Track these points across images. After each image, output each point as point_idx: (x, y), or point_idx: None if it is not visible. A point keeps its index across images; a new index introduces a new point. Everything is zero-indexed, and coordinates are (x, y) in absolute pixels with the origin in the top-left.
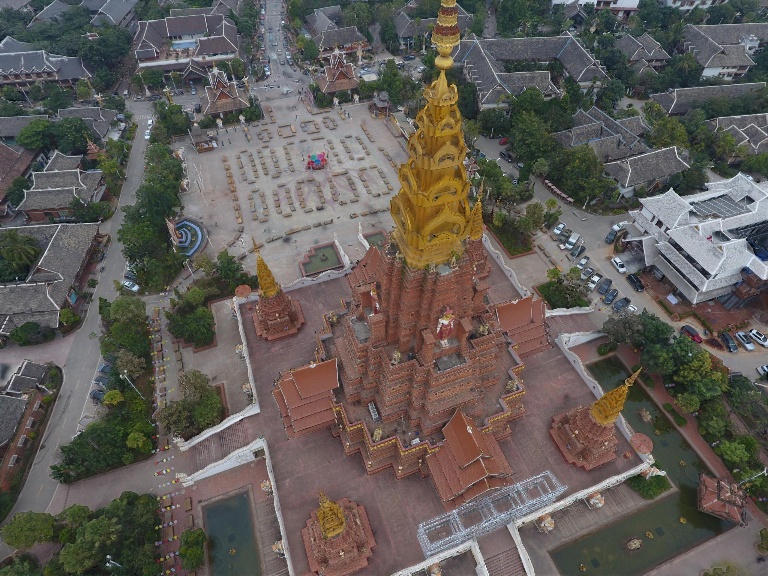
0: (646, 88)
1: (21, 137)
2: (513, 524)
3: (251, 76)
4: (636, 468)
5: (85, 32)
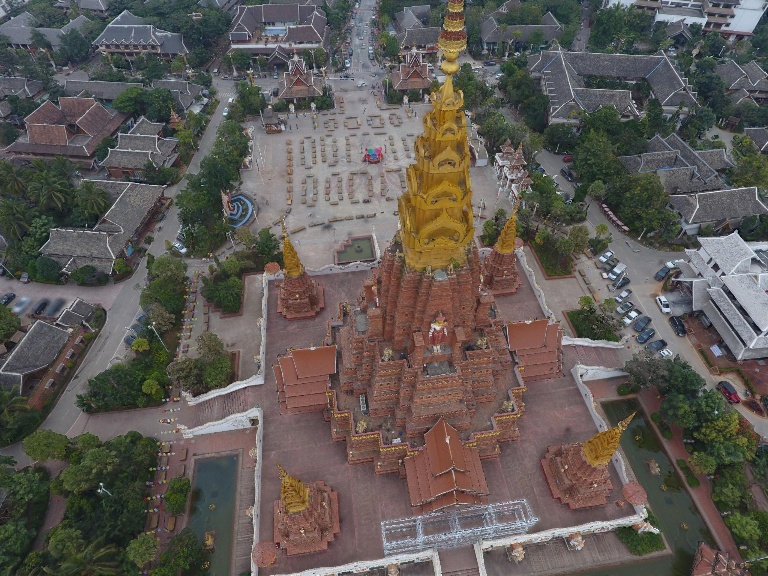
0: (742, 120)
1: (117, 101)
2: (478, 544)
3: (331, 66)
4: (625, 518)
5: (191, 12)
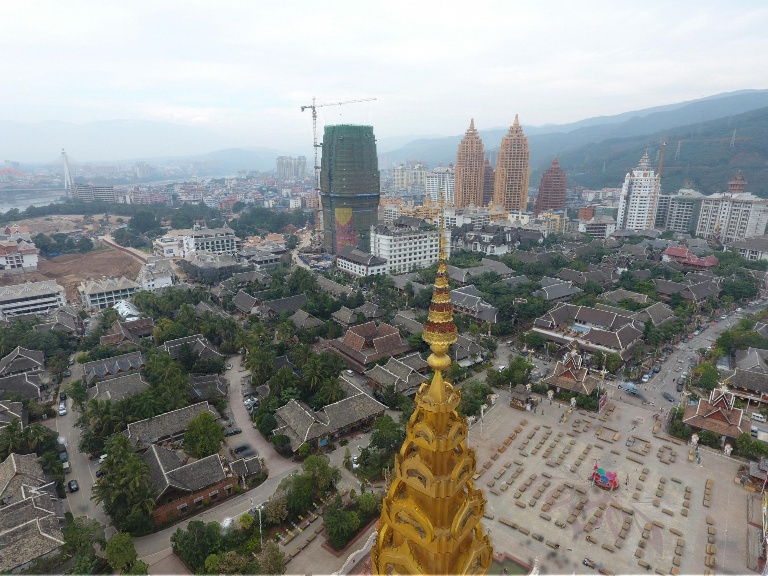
0: None
1: (412, 336)
2: None
3: (622, 374)
4: None
5: (520, 297)
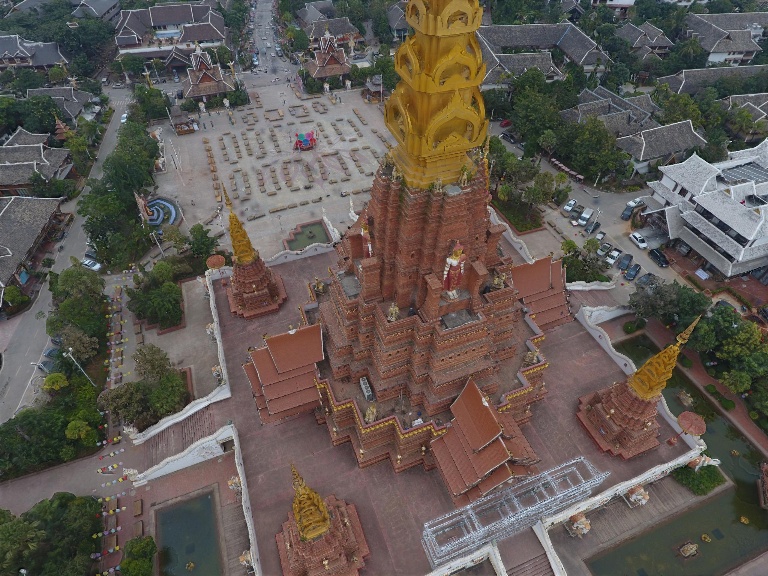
0: (651, 74)
1: None
2: (541, 524)
3: (238, 65)
4: (686, 455)
5: (65, 21)
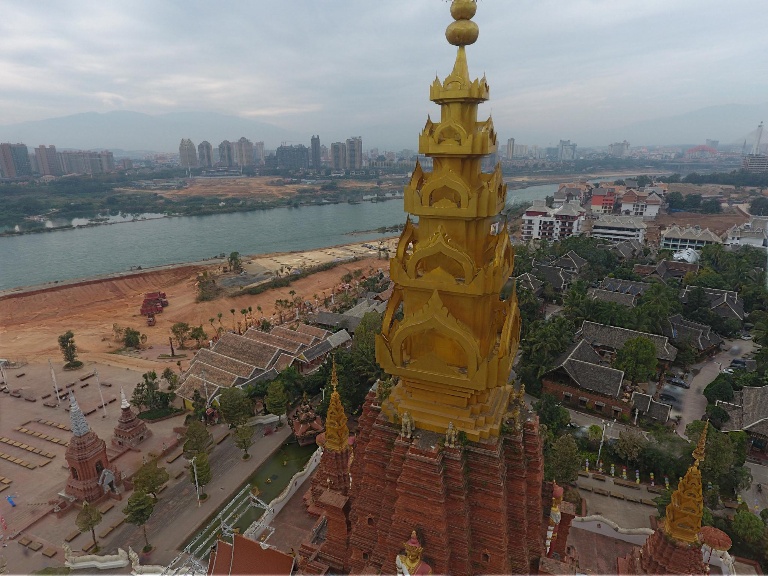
0: None
1: None
2: None
3: None
4: None
5: None
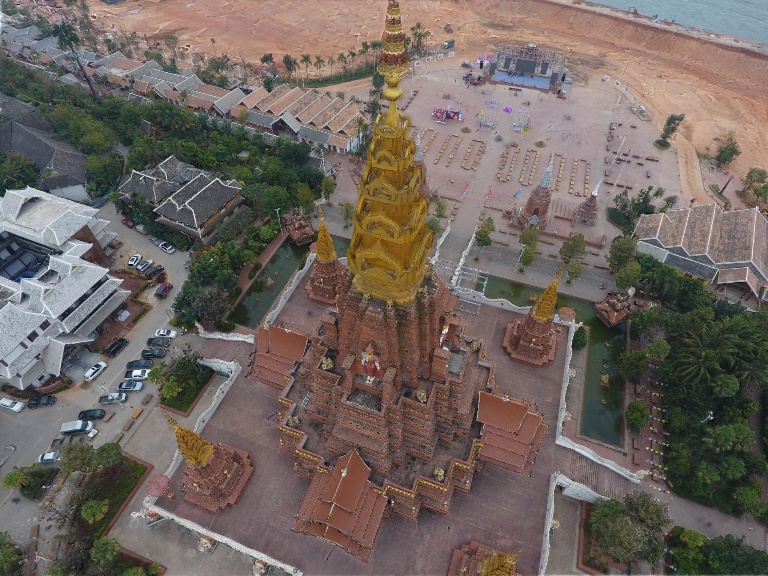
0: None
1: None
2: None
3: None
4: None
5: None
